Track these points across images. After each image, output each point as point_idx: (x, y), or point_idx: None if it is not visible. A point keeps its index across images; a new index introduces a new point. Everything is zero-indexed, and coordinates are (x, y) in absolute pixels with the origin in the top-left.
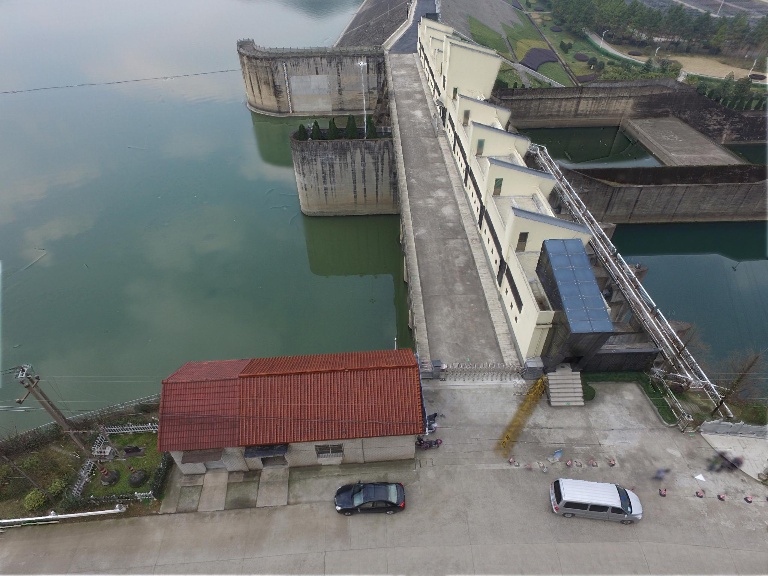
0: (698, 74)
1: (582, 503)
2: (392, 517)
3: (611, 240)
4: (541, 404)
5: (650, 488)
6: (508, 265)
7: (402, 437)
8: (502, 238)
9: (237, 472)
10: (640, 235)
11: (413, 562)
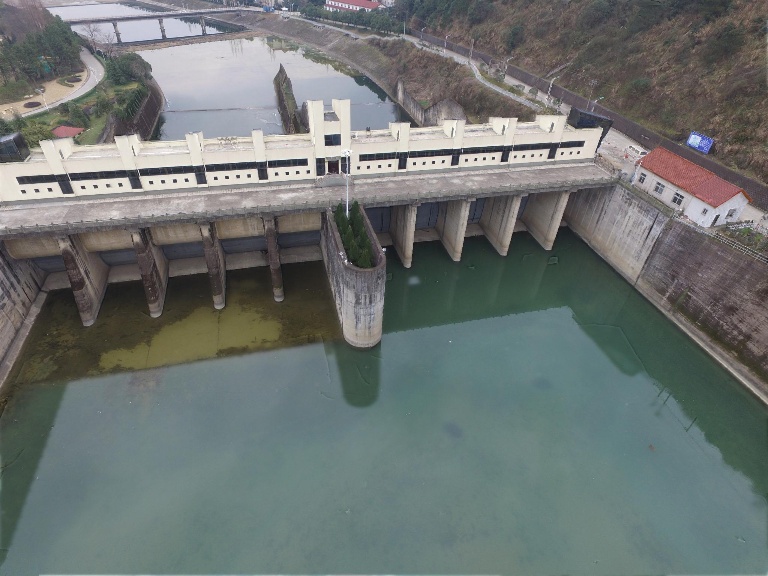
0: None
1: None
2: None
3: None
4: None
5: None
6: (562, 141)
7: None
8: None
9: None
10: None
11: None
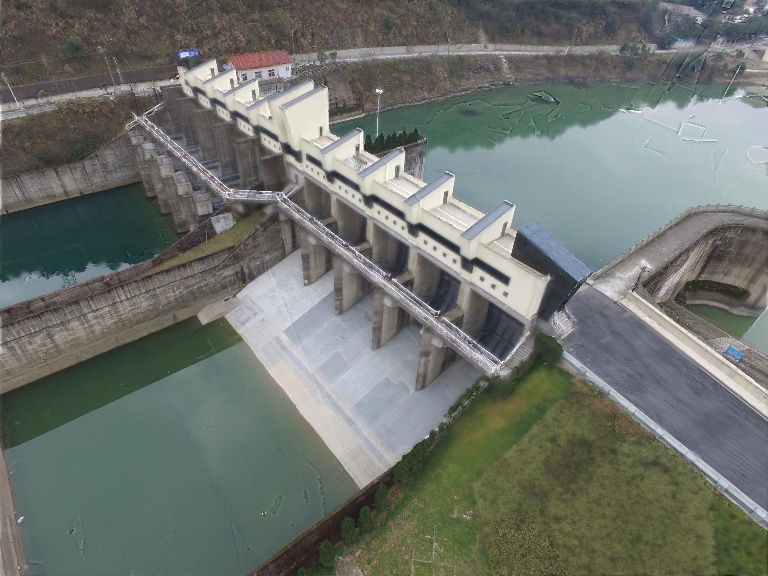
0: None
1: None
2: None
3: None
4: None
5: None
6: None
7: None
8: None
9: None
10: None
11: None
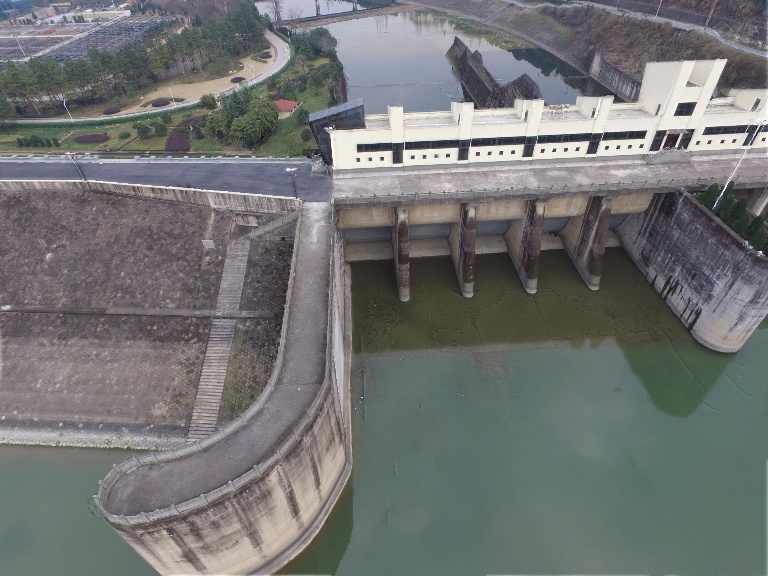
0: None
1: None
2: None
3: None
4: None
5: None
6: None
7: None
8: None
9: None
10: None
11: None
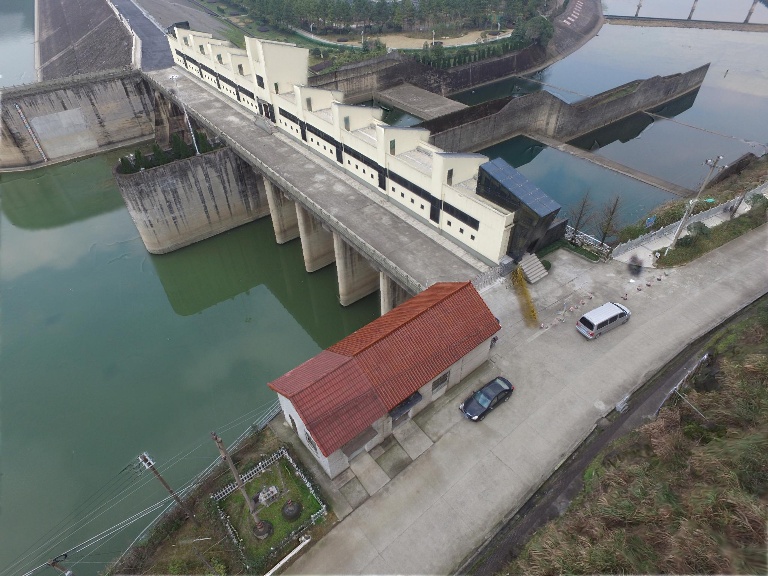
0: (398, 48)
1: (605, 321)
2: (509, 402)
3: None
4: (526, 286)
5: (617, 299)
6: (445, 201)
7: (485, 341)
8: (427, 183)
9: (374, 448)
10: None
11: (546, 417)
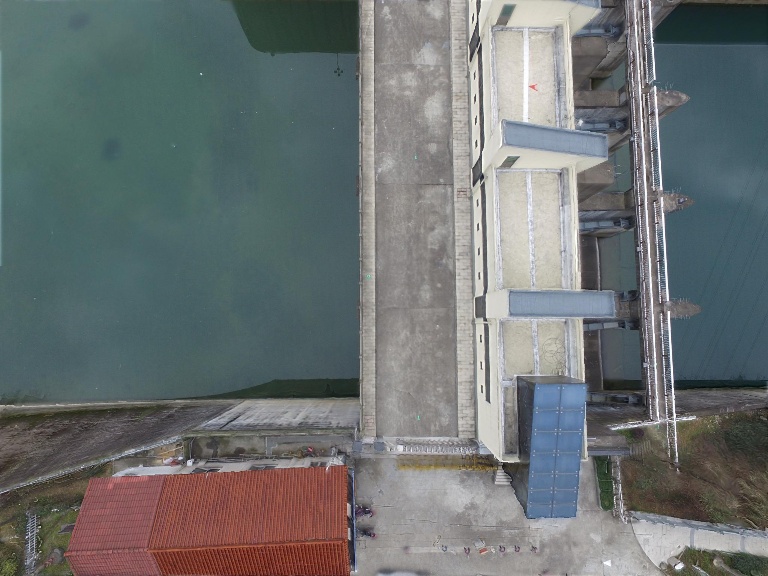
0: None
1: None
2: None
3: (686, 24)
4: (485, 480)
5: (559, 573)
6: (488, 326)
7: None
8: (491, 280)
9: None
10: (732, 19)
11: None
